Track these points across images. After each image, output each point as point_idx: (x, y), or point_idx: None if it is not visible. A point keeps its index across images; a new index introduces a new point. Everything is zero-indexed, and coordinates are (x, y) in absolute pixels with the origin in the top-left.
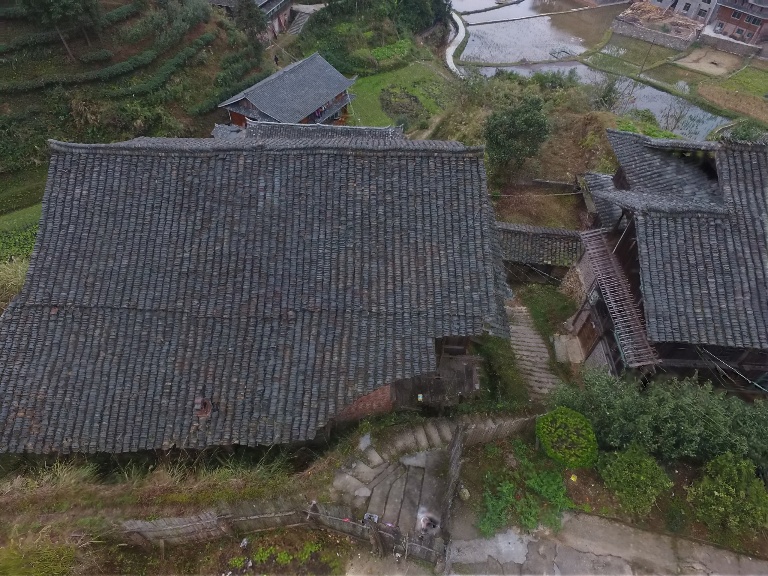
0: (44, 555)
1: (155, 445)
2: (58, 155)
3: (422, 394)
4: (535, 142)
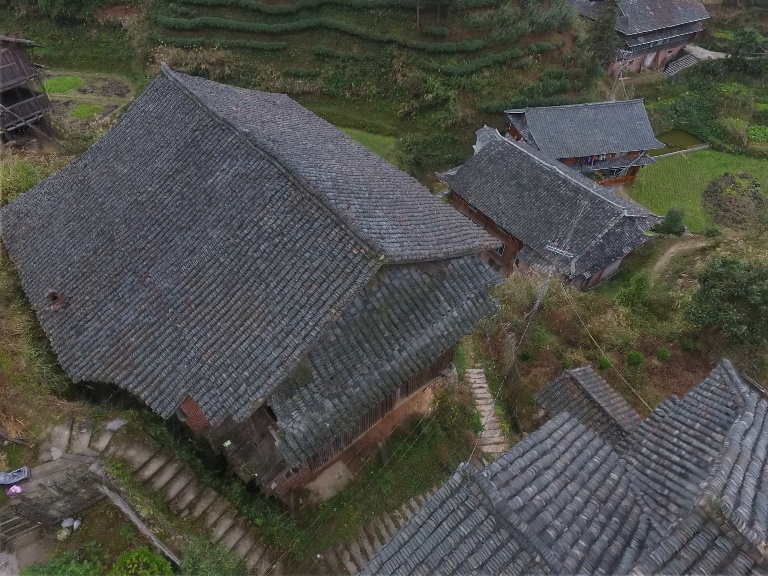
0: None
1: (32, 301)
2: (162, 76)
3: (231, 443)
4: (766, 328)
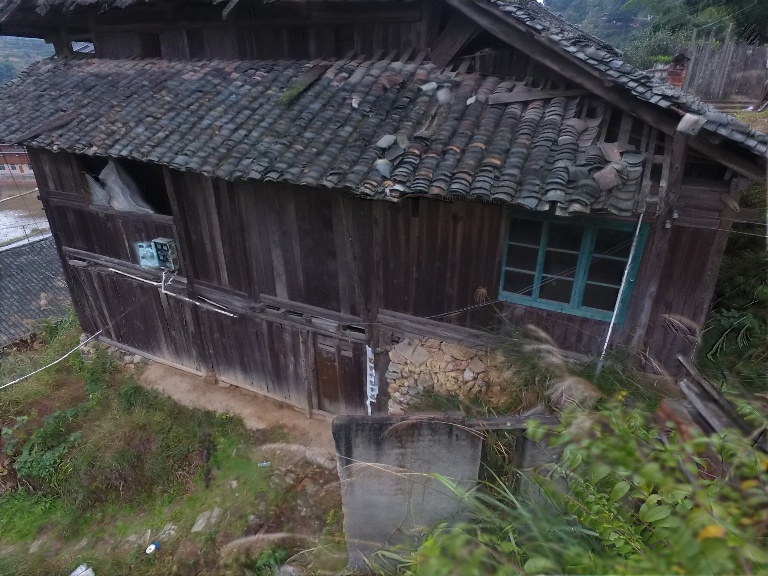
0: None
1: None
2: None
3: None
4: None
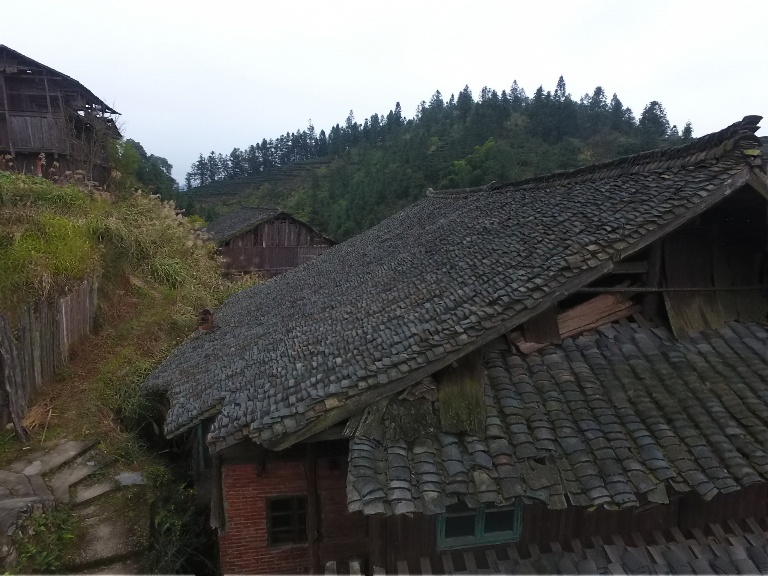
0: None
1: None
2: None
3: None
4: None
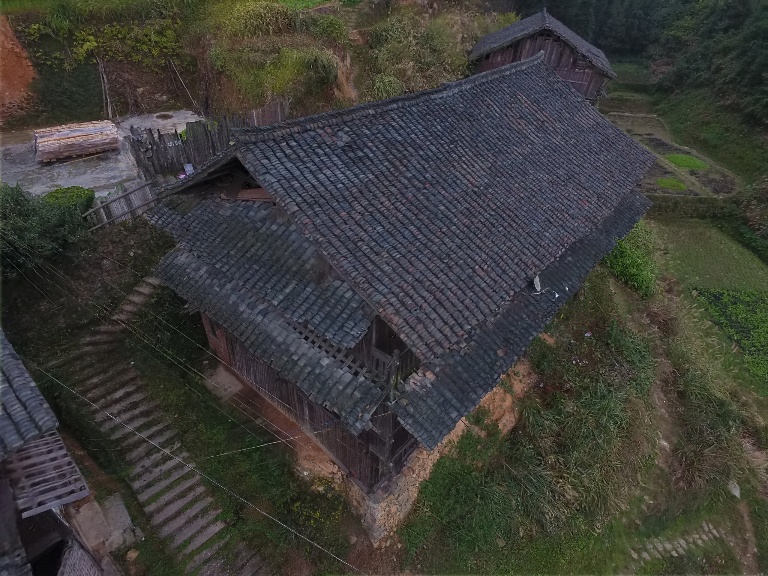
0: None
1: None
2: None
3: None
4: None
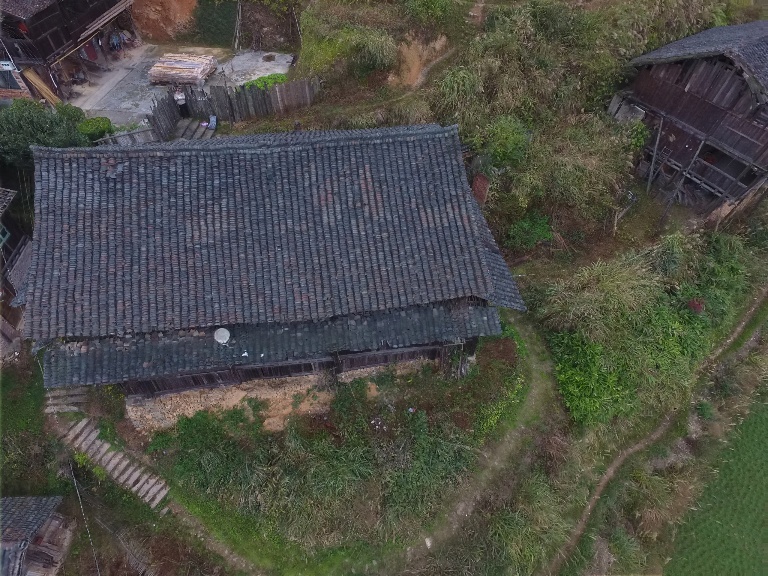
0: (321, 64)
1: None
2: None
3: None
4: None
